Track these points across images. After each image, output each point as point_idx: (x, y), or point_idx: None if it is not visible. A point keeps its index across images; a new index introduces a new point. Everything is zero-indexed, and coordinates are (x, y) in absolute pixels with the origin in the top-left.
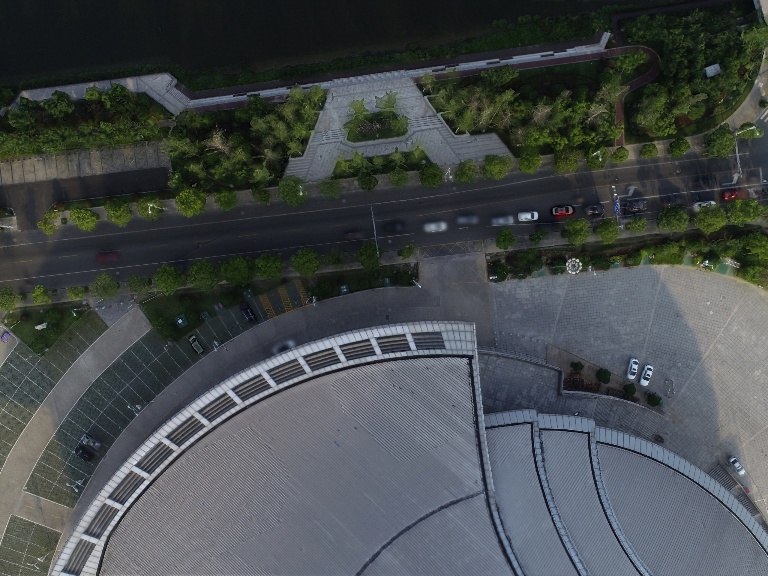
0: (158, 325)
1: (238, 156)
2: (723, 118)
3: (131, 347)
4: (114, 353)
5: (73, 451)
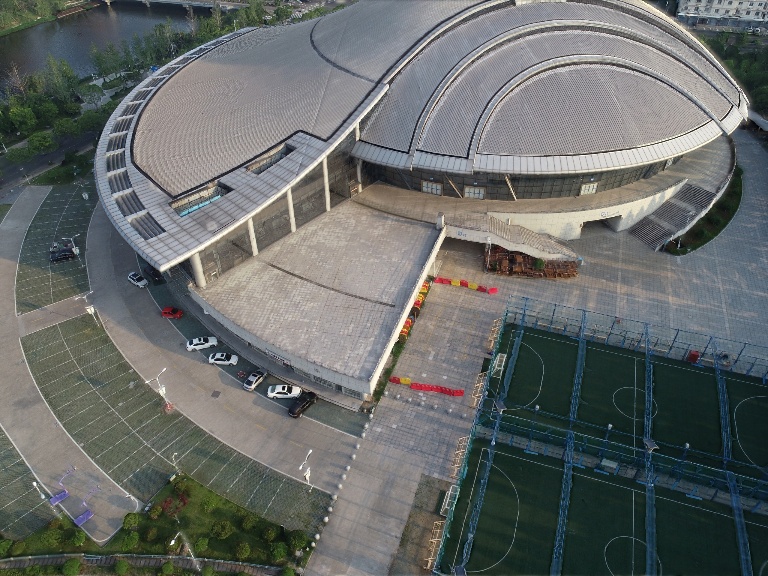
0: (56, 171)
1: (38, 88)
2: (276, 23)
3: (45, 201)
4: (32, 210)
5: (49, 266)
